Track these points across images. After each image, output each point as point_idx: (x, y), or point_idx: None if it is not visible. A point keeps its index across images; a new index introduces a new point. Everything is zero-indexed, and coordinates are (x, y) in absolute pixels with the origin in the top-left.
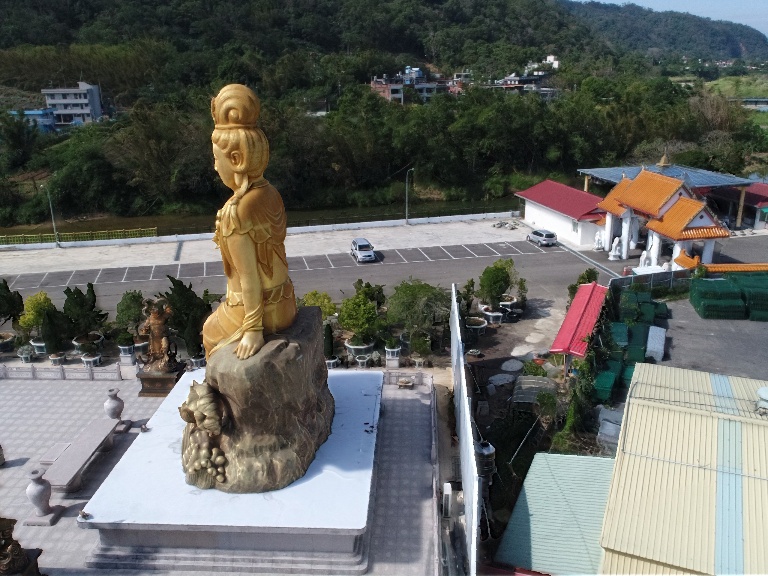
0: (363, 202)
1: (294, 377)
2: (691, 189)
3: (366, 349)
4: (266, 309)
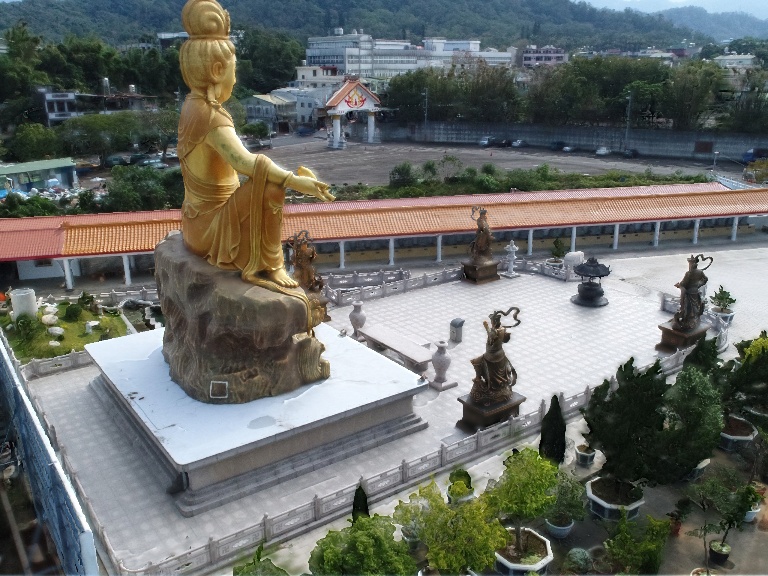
0: None
1: None
2: None
3: None
4: None
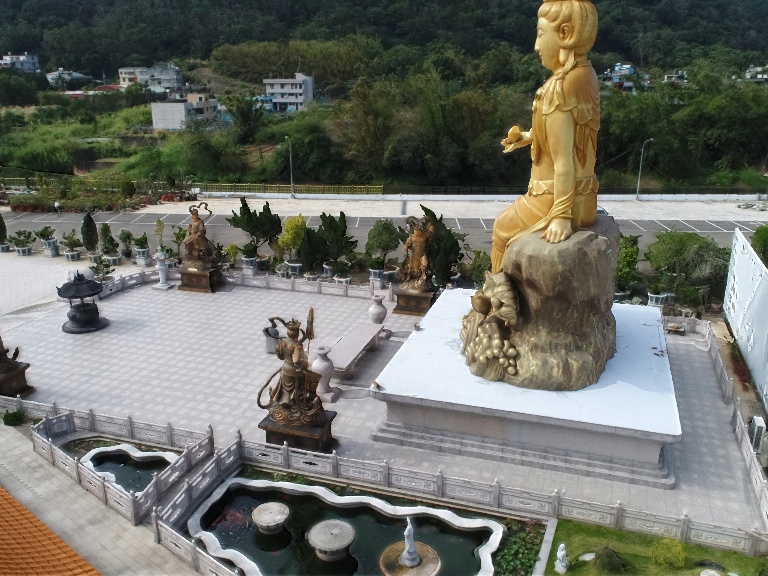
0: None
1: (602, 271)
2: None
3: (622, 296)
4: None
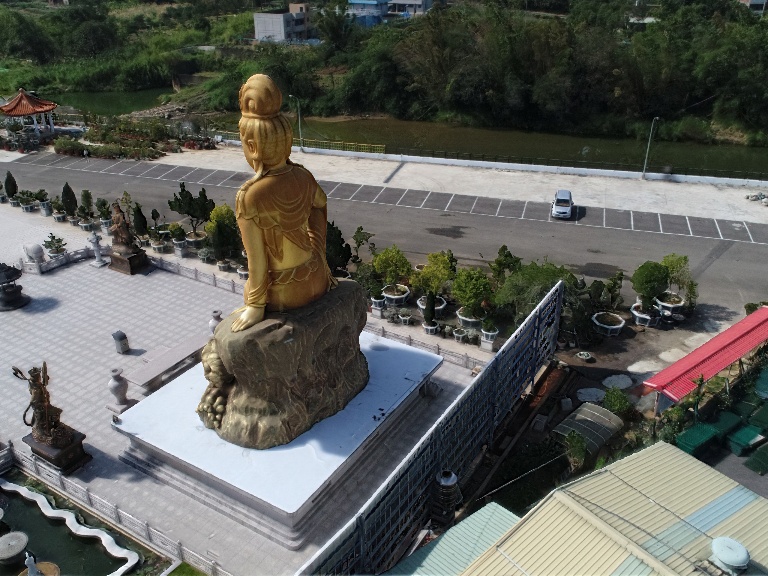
0: (643, 135)
1: (280, 357)
2: None
3: (474, 322)
4: (274, 288)
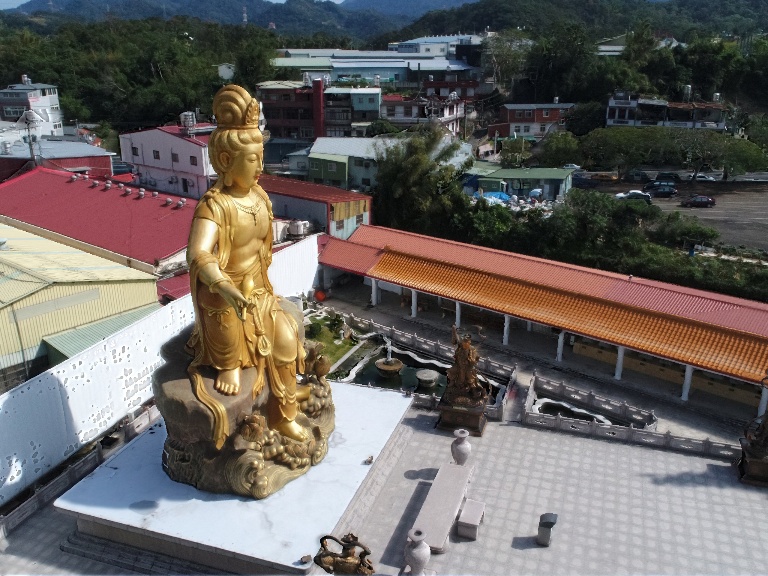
0: None
1: None
2: None
3: None
4: None
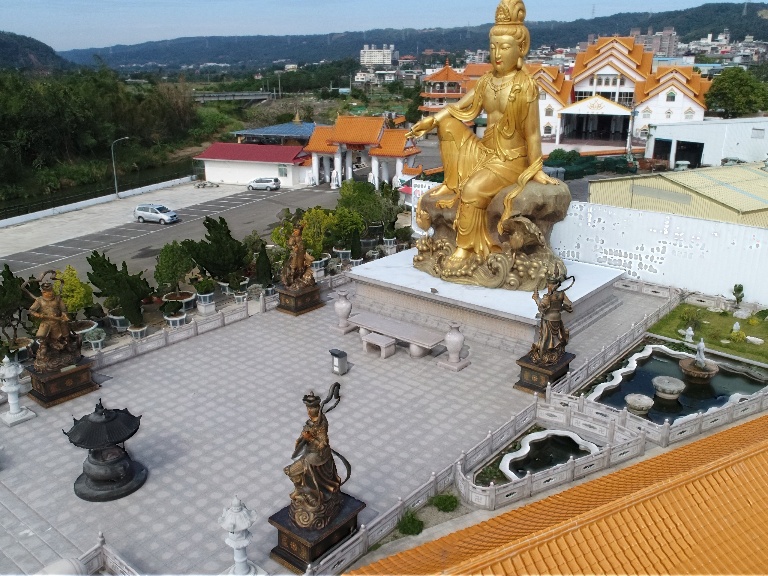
0: None
1: None
2: (388, 123)
3: None
4: None
